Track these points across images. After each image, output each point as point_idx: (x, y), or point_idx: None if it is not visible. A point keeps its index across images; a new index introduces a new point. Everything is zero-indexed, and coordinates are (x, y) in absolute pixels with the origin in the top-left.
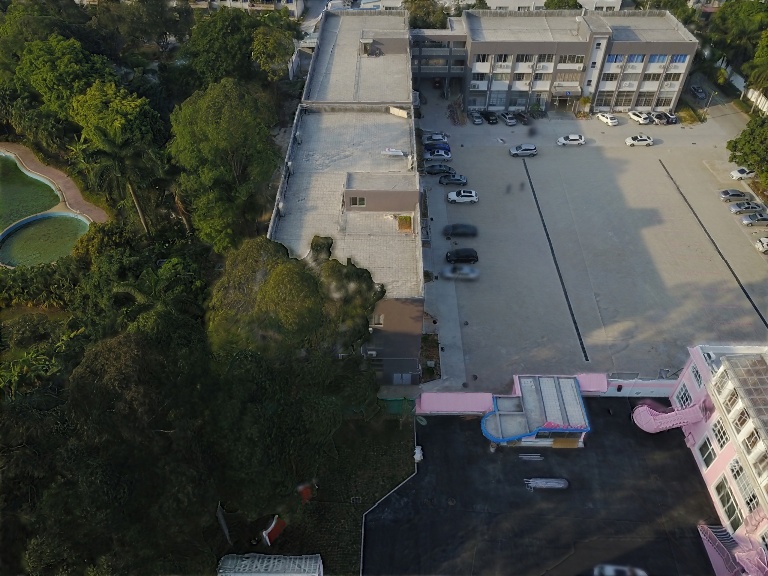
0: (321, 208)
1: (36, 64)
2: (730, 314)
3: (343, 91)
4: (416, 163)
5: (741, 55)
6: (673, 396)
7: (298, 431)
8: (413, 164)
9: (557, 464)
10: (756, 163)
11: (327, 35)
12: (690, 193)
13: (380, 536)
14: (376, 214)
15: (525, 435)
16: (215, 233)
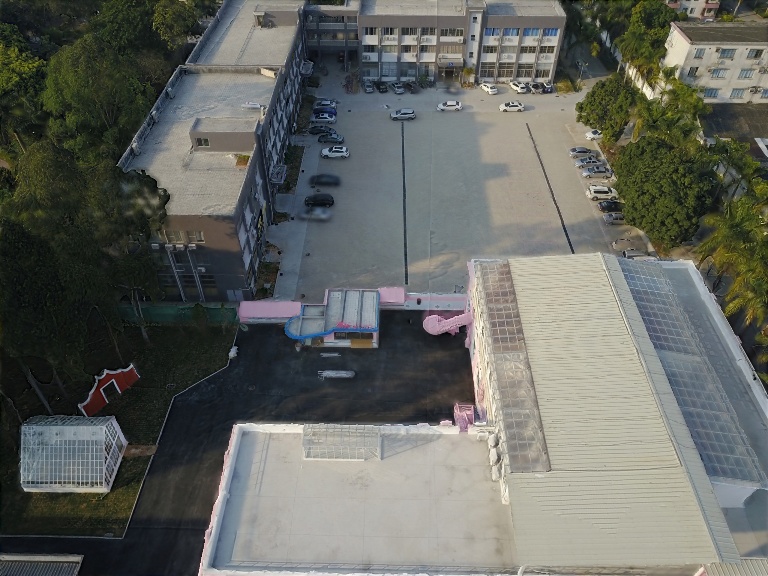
0: (173, 149)
1: None
2: (545, 248)
3: (228, 57)
4: (266, 113)
5: (621, 32)
6: (466, 309)
7: (54, 287)
8: None
9: (351, 360)
10: (596, 122)
11: (231, 10)
12: (545, 151)
13: (183, 412)
14: (220, 154)
15: (320, 333)
16: None
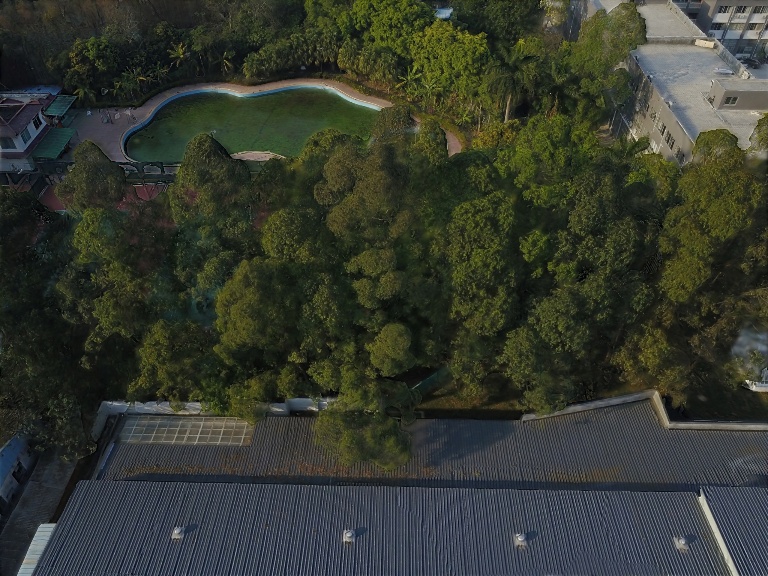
0: (695, 108)
1: (376, 7)
2: None
3: None
4: None
5: None
6: None
7: None
8: (749, 78)
9: None
10: None
11: None
12: None
13: None
14: (743, 112)
15: None
16: (584, 134)
